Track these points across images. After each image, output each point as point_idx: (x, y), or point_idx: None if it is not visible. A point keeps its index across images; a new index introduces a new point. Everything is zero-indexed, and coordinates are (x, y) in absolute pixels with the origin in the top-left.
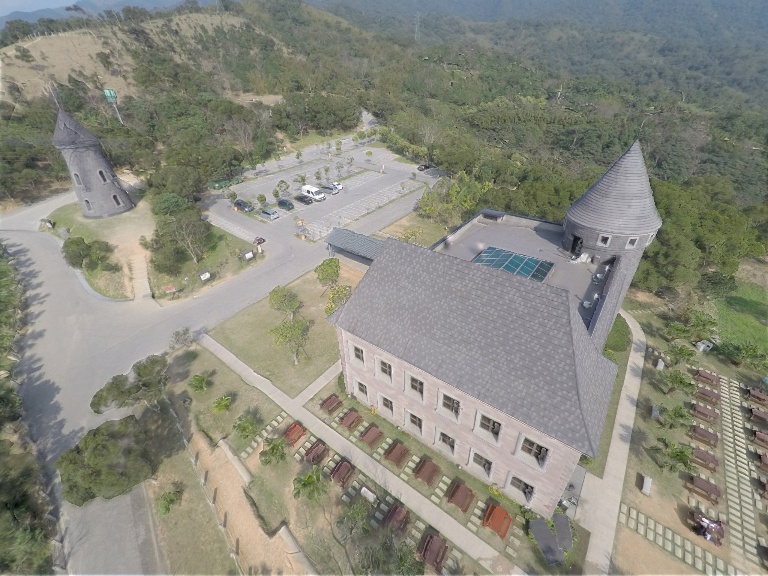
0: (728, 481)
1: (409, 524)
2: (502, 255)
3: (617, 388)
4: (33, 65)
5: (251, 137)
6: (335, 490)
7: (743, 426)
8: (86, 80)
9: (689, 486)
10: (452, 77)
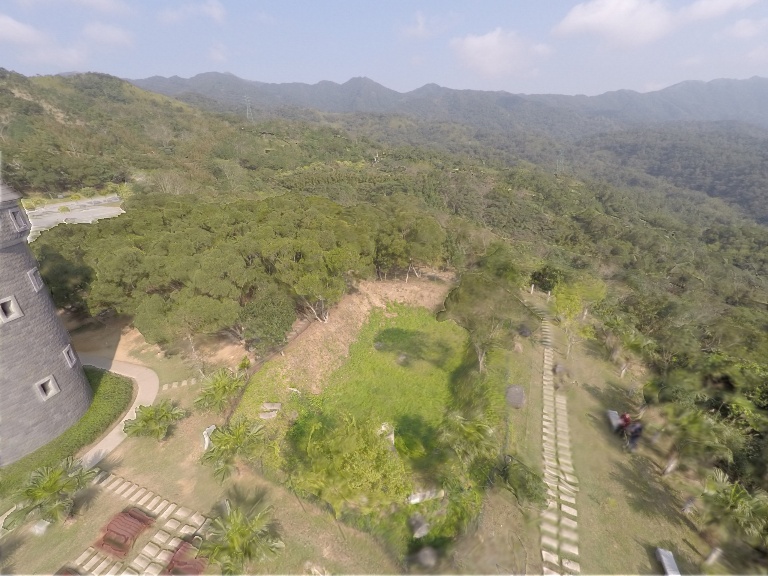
0: None
1: None
2: None
3: None
4: None
5: None
6: None
7: None
8: None
9: None
10: (269, 145)
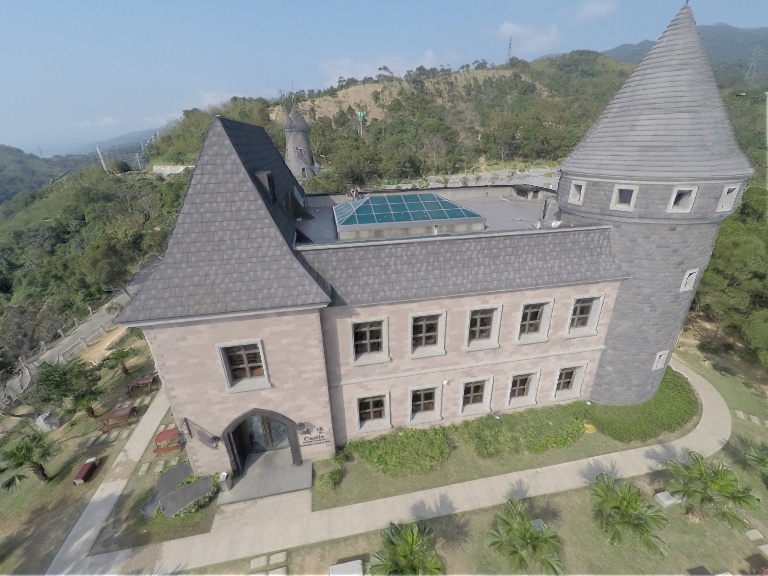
0: None
1: (145, 395)
2: None
3: (519, 464)
4: (336, 100)
5: (445, 153)
6: None
7: None
8: (359, 109)
9: None
10: None
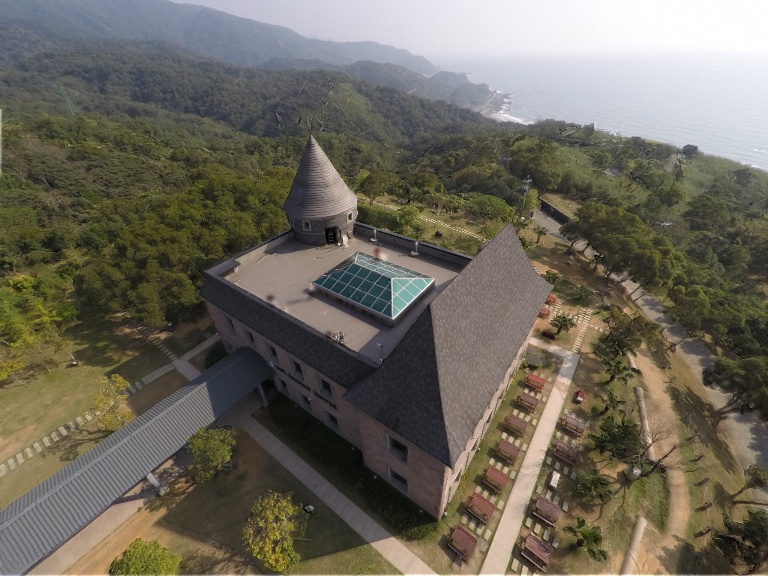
0: None
1: None
2: (350, 272)
3: None
4: None
5: None
6: (561, 521)
7: None
8: None
9: None
10: None
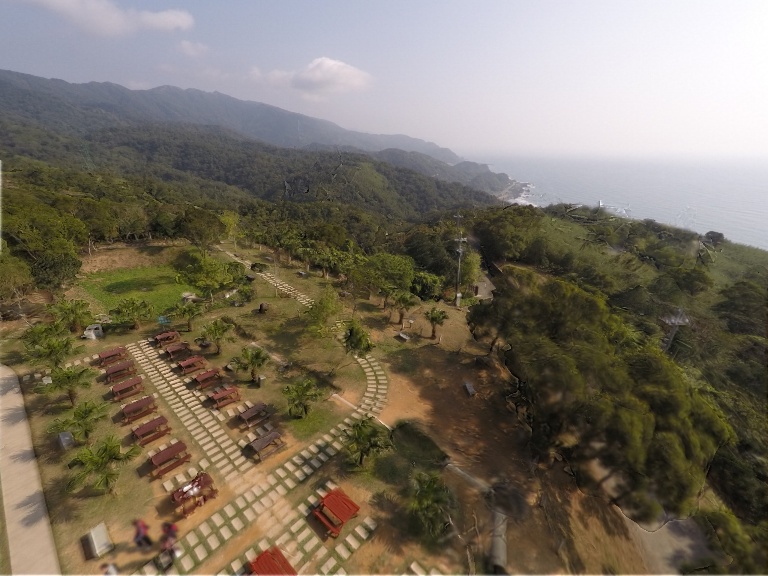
0: (188, 425)
1: None
2: None
3: None
4: None
5: None
6: None
7: (171, 369)
8: None
9: (156, 473)
10: None
